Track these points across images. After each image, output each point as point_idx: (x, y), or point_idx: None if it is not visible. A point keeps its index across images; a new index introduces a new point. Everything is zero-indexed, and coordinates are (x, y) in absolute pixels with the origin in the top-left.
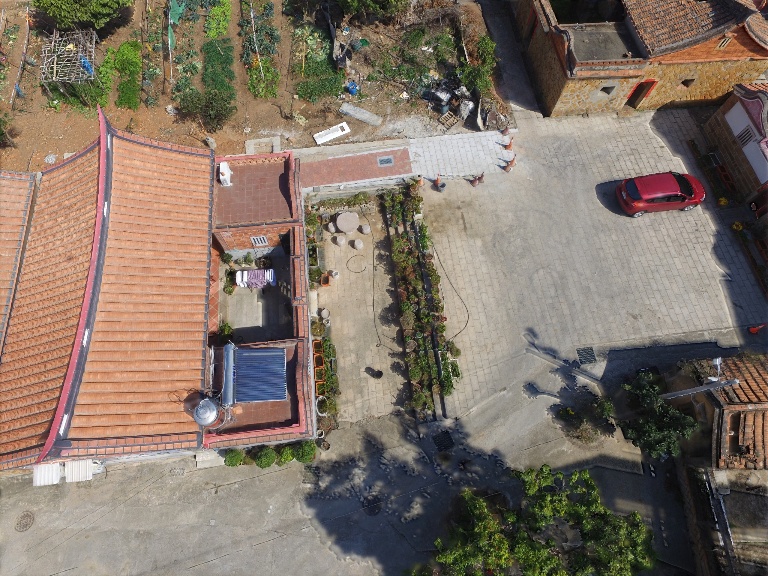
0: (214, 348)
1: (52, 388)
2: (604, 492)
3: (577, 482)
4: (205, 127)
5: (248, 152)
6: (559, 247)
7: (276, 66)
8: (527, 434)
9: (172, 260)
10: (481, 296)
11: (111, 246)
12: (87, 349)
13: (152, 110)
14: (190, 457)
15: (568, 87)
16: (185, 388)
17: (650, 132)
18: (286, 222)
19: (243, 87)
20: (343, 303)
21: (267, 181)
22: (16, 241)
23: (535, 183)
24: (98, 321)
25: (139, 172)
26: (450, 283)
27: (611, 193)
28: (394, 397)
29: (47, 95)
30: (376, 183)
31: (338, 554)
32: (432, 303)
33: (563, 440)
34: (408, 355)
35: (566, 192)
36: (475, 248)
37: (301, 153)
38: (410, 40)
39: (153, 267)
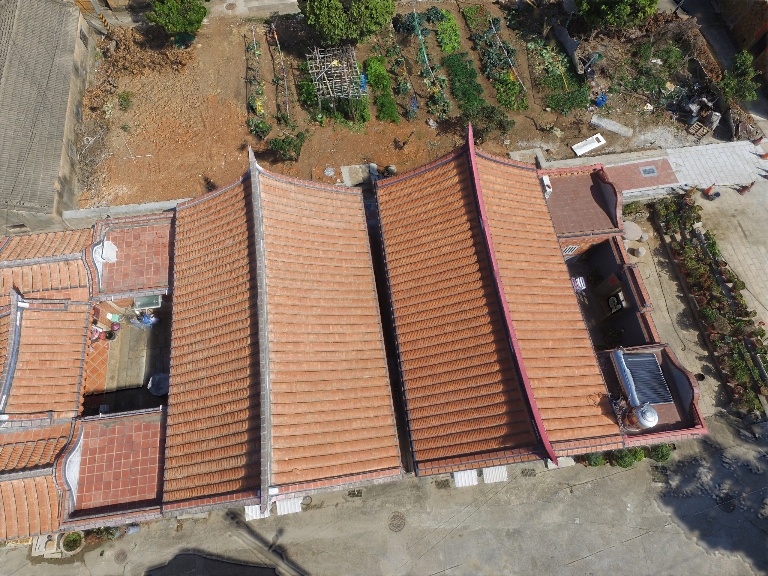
0: None
1: (487, 394)
2: None
3: None
4: None
5: None
6: None
7: None
8: None
9: (542, 270)
10: None
11: (496, 258)
12: None
13: (414, 123)
14: None
15: None
16: (595, 392)
17: None
18: (612, 232)
19: (492, 100)
20: None
21: (580, 193)
22: (366, 253)
23: None
24: None
25: (494, 186)
26: (746, 289)
27: None
28: (713, 399)
29: (307, 110)
30: (647, 193)
31: (707, 549)
32: (738, 308)
33: None
34: (721, 358)
35: None
36: (760, 255)
37: (567, 164)
38: (643, 53)
39: (530, 277)
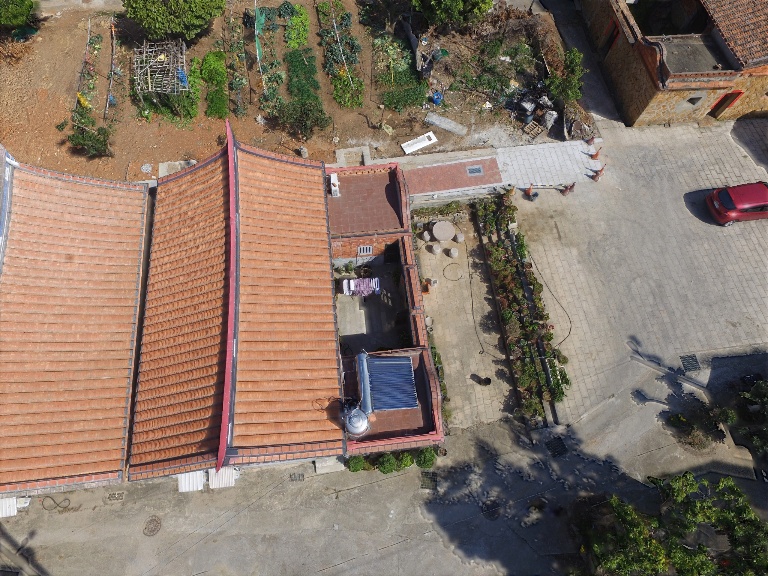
0: (341, 357)
1: (202, 397)
2: None
3: None
4: (295, 137)
5: (340, 161)
6: (653, 256)
7: (359, 76)
8: (639, 440)
9: (299, 270)
10: (581, 304)
11: (243, 257)
12: (236, 359)
13: (242, 120)
14: (308, 463)
15: (657, 98)
16: (325, 396)
17: (732, 142)
18: (397, 232)
19: (328, 97)
20: (443, 311)
21: (374, 192)
22: (137, 251)
23: (624, 192)
24: (241, 331)
25: (261, 184)
26: (550, 291)
27: (699, 202)
28: (501, 404)
29: (137, 105)
30: (468, 192)
31: (462, 558)
32: (535, 311)
33: (675, 446)
34: (513, 362)
35: (655, 201)
36: (571, 257)
37: None
38: (489, 50)
39: (283, 278)
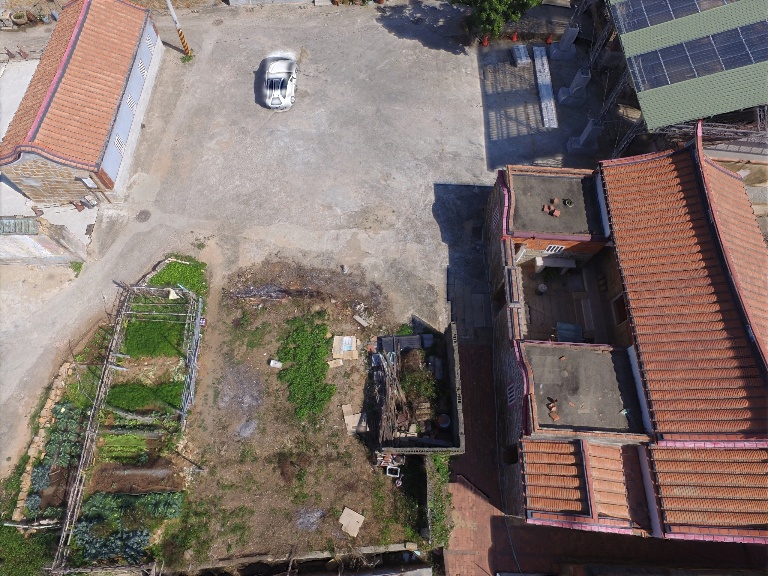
0: None
1: None
2: (548, 13)
3: (533, 9)
4: None
5: None
6: None
7: None
8: None
9: None
10: None
11: None
12: None
13: None
14: (310, 2)
15: None
16: None
17: None
18: None
19: None
20: None
21: None
22: None
23: None
24: None
25: None
26: None
27: None
28: None
29: None
30: None
31: (399, 37)
32: None
33: None
34: None
35: None
36: None
37: None
38: None
39: None
